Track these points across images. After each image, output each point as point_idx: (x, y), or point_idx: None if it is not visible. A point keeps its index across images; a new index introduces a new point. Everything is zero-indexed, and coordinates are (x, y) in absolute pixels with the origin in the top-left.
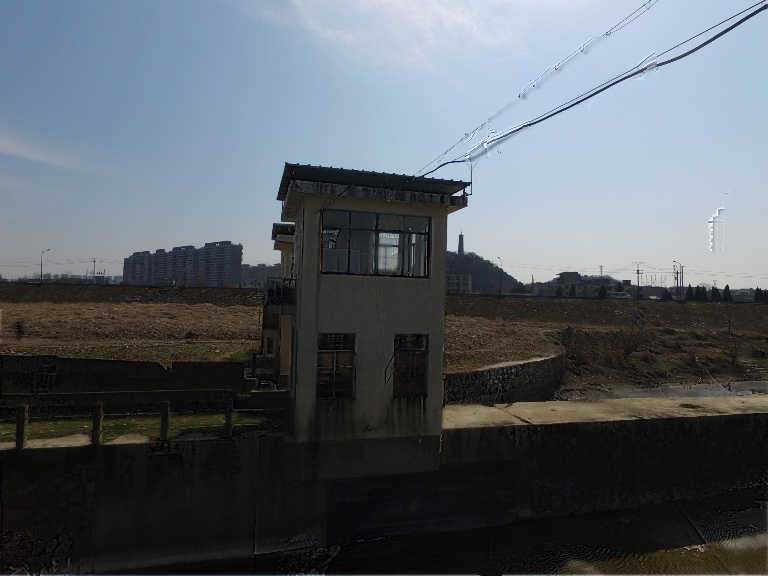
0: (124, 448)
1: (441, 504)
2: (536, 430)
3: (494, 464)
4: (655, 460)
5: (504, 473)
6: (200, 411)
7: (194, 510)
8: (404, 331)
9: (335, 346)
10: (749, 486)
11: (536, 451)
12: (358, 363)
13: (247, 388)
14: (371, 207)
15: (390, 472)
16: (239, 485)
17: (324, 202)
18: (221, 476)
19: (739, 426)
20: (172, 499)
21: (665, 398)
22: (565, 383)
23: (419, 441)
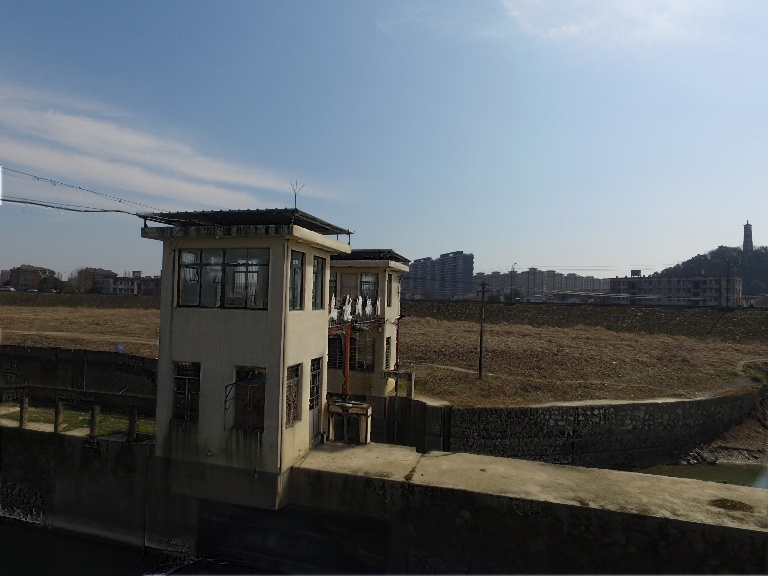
0: (69, 438)
1: (299, 547)
2: (412, 490)
3: (359, 519)
4: (604, 571)
5: (371, 532)
6: (115, 417)
7: (107, 496)
8: (242, 363)
9: (188, 373)
10: None
11: (410, 515)
12: (202, 391)
13: None
14: (215, 243)
15: (229, 500)
16: (135, 483)
17: (177, 243)
18: (124, 473)
19: None
20: (95, 484)
21: (718, 484)
22: (728, 438)
23: (256, 475)
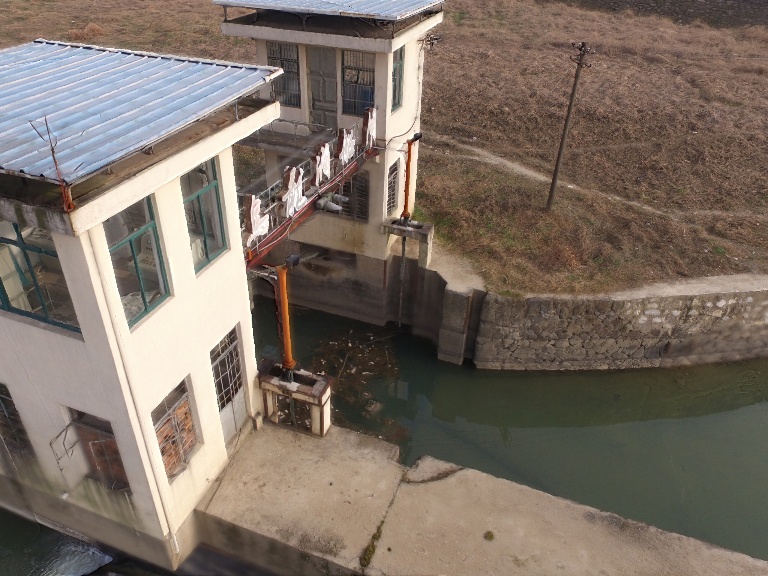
0: None
1: None
2: None
3: None
4: None
5: None
6: None
7: None
8: (71, 404)
9: None
10: None
11: None
12: (25, 421)
13: None
14: None
15: (111, 544)
16: None
17: None
18: None
19: None
20: None
21: None
22: None
23: (137, 533)
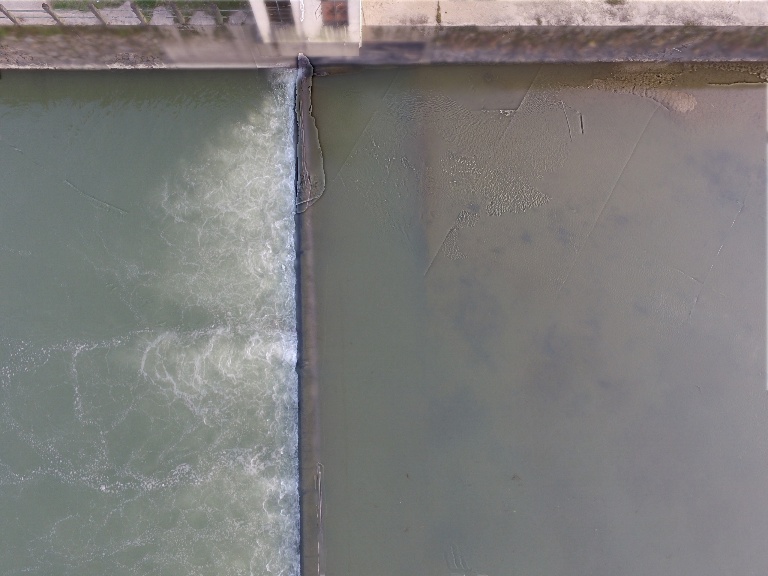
0: (162, 27)
1: (367, 58)
2: (442, 29)
3: (406, 43)
4: (536, 47)
5: (413, 47)
6: (197, 10)
7: (216, 51)
8: None
9: None
10: (613, 61)
11: (439, 40)
12: (294, 8)
13: None
14: None
15: (326, 55)
16: (237, 44)
17: None
18: (225, 40)
19: (630, 32)
20: (202, 47)
21: None
22: None
23: (344, 44)
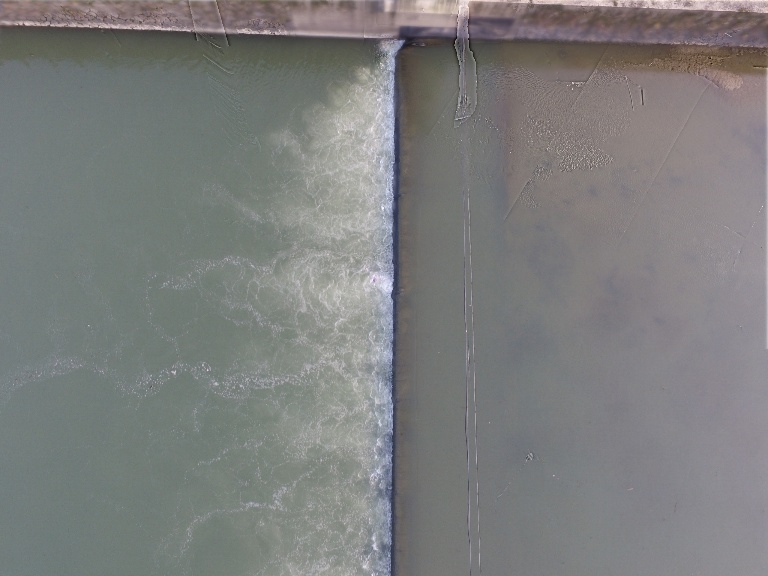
0: None
1: None
2: (533, 6)
3: (498, 19)
4: (609, 27)
5: (503, 23)
6: None
7: (335, 20)
8: None
9: None
10: (671, 43)
11: (528, 16)
12: None
13: None
14: None
15: (432, 26)
16: (356, 14)
17: None
18: (347, 10)
19: (691, 16)
20: (325, 16)
21: None
22: None
23: (451, 16)
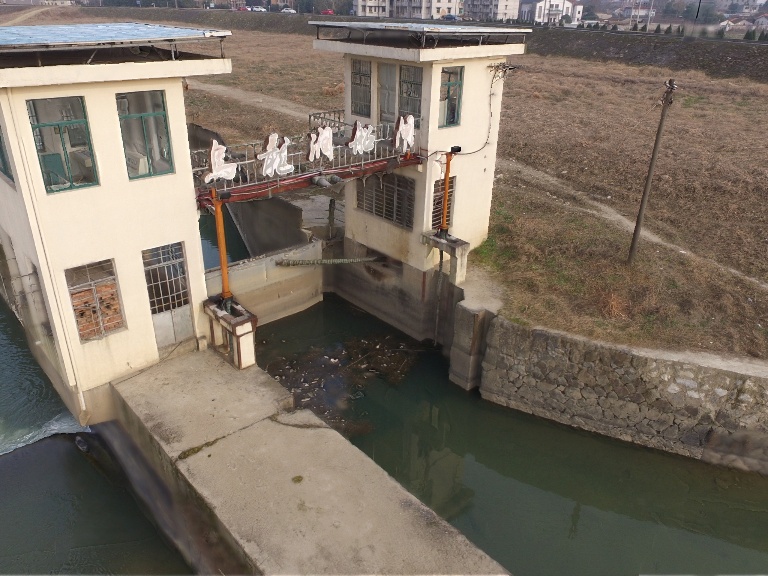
0: None
1: None
2: (178, 474)
3: None
4: None
5: None
6: None
7: None
8: None
9: None
10: None
11: (178, 500)
12: None
13: (302, 240)
14: None
15: None
16: None
17: None
18: None
19: None
20: None
21: None
22: None
23: None
